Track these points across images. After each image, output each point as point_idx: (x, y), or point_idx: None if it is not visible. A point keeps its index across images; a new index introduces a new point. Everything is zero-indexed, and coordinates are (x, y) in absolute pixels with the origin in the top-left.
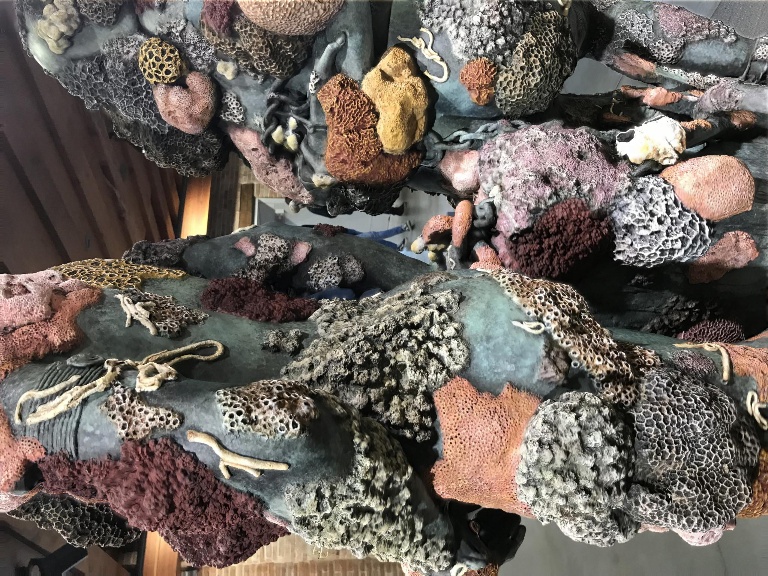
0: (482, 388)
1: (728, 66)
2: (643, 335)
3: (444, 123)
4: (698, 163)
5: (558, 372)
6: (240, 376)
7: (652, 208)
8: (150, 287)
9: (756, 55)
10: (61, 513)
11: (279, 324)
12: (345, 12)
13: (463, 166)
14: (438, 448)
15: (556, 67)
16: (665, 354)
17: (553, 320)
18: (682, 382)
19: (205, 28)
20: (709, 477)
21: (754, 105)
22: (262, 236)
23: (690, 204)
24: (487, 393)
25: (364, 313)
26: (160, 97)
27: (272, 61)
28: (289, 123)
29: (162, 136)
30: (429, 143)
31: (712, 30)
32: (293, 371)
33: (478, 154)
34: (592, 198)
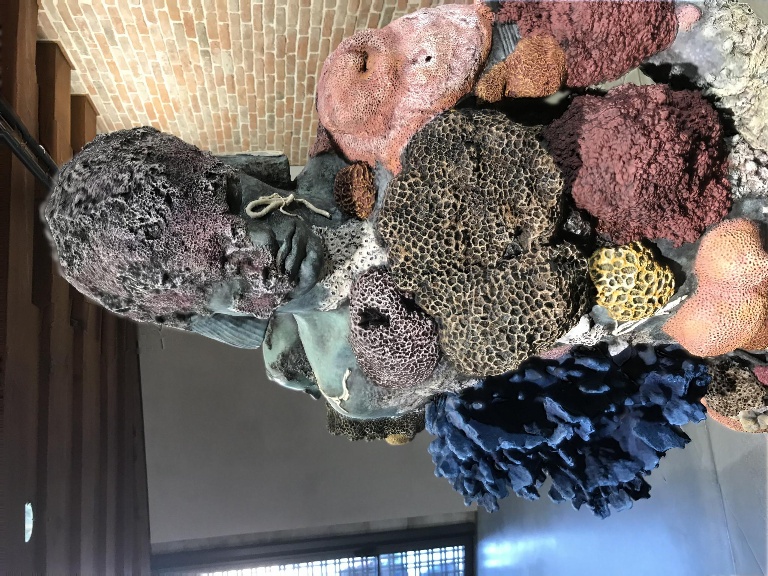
0: None
1: None
2: None
3: None
4: None
5: None
6: None
7: None
8: None
9: None
10: (493, 117)
11: None
12: None
13: None
14: None
15: None
16: None
17: None
18: None
19: None
20: None
21: None
22: None
23: None
24: None
25: None
26: None
27: None
28: None
29: None
30: None
31: None
32: None
33: None
34: None
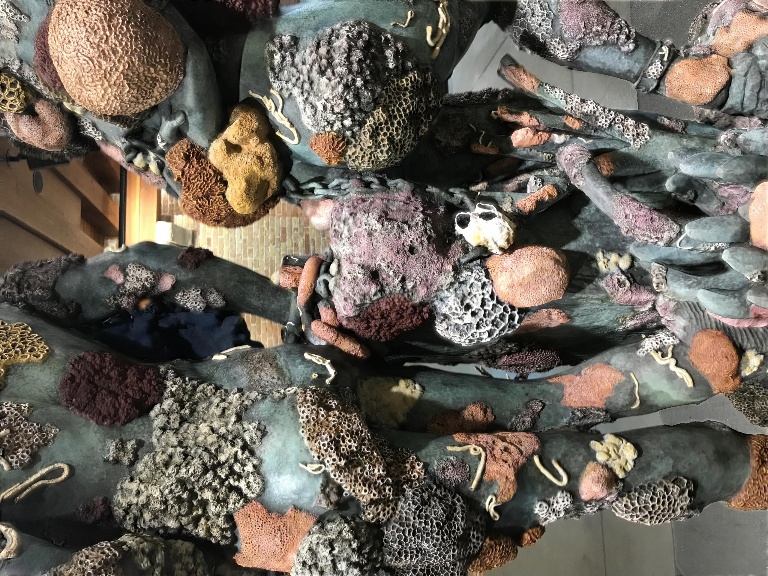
0: (272, 509)
1: (621, 74)
2: (452, 390)
3: (301, 169)
4: (518, 263)
5: (329, 505)
6: (84, 491)
7: (469, 301)
8: (13, 376)
9: (647, 73)
10: None
11: (122, 427)
12: (182, 92)
13: (319, 212)
14: (238, 546)
15: (408, 138)
16: (432, 463)
17: (331, 465)
18: (431, 502)
19: (40, 81)
20: (435, 569)
21: (590, 197)
22: (129, 266)
23: (504, 298)
24: (275, 513)
25: (195, 414)
26: (10, 124)
27: (115, 123)
28: (149, 152)
29: (24, 143)
30: (287, 186)
31: (611, 36)
32: (126, 489)
33: (333, 203)
34: (415, 293)
